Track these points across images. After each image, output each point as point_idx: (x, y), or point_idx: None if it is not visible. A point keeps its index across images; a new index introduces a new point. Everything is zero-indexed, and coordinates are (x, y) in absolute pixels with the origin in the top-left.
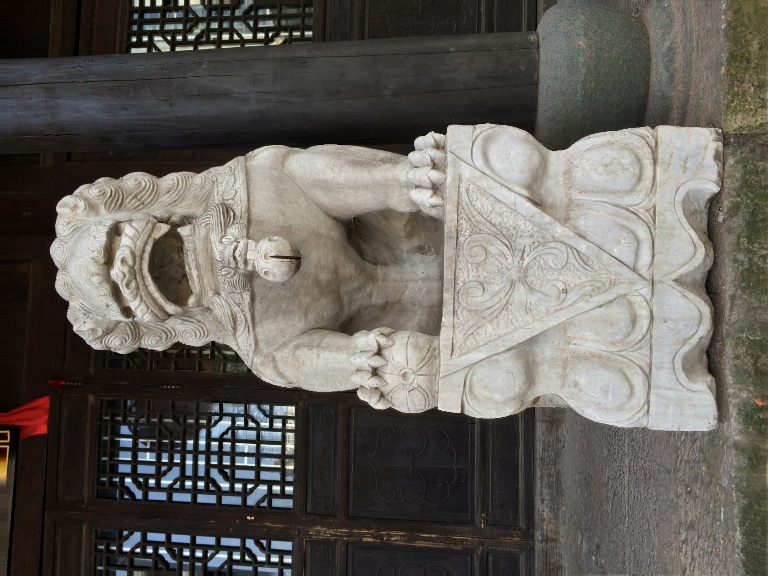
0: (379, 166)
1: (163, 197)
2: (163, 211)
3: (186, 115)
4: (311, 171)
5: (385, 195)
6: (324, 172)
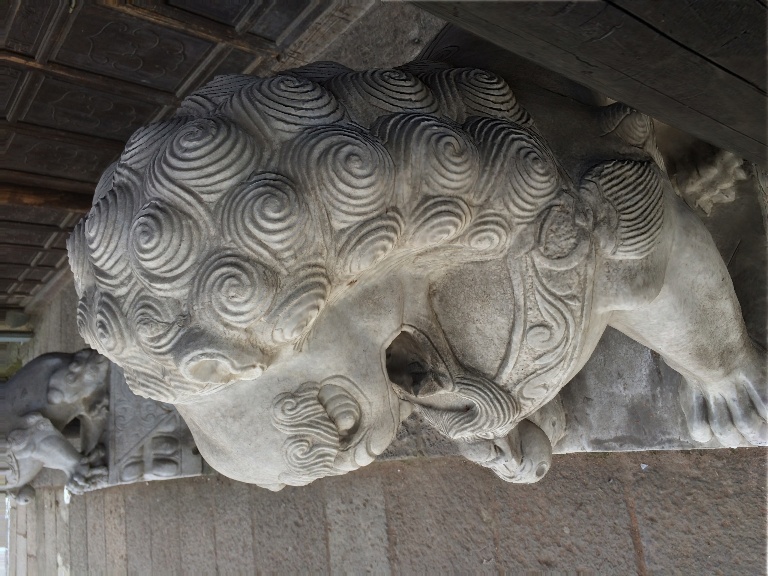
0: (712, 370)
1: (394, 252)
2: (396, 327)
3: (586, 83)
4: (648, 329)
5: (674, 364)
6: (659, 341)
